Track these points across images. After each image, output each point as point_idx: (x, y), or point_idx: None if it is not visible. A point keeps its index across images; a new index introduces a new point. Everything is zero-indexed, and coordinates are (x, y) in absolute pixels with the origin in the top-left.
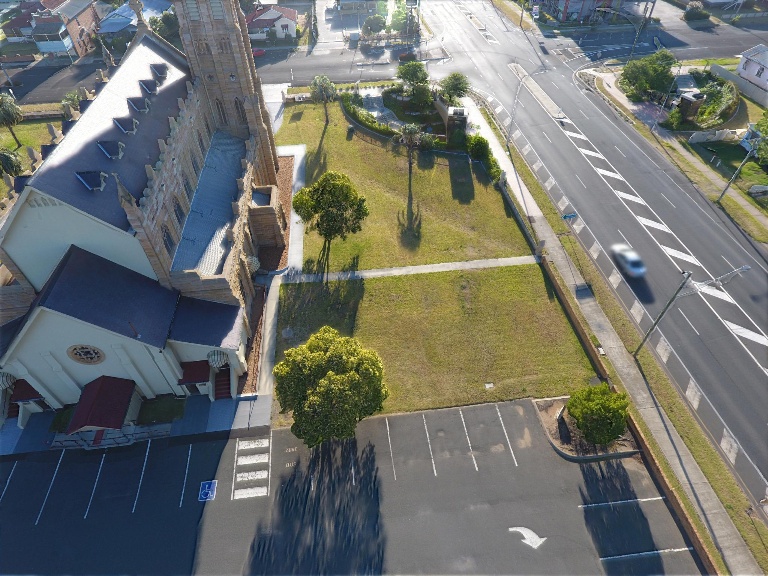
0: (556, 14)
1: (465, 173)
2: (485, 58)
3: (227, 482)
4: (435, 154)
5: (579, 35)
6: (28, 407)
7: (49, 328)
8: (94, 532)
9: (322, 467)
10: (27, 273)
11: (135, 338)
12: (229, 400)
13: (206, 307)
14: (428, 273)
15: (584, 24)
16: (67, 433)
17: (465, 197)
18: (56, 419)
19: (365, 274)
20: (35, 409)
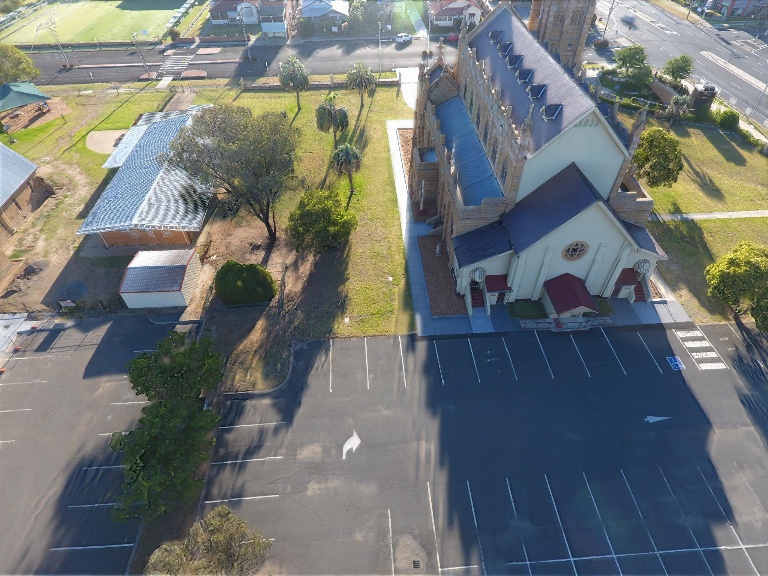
0: (719, 9)
1: (724, 141)
2: (674, 47)
3: (688, 358)
4: (685, 125)
5: (749, 29)
6: (491, 299)
7: (579, 223)
8: (605, 386)
9: (759, 352)
10: (521, 186)
11: (630, 236)
12: (645, 303)
13: (629, 225)
14: (748, 217)
15: (750, 19)
16: (559, 313)
17: (738, 160)
18: (511, 310)
19: (693, 216)
20: (493, 301)
